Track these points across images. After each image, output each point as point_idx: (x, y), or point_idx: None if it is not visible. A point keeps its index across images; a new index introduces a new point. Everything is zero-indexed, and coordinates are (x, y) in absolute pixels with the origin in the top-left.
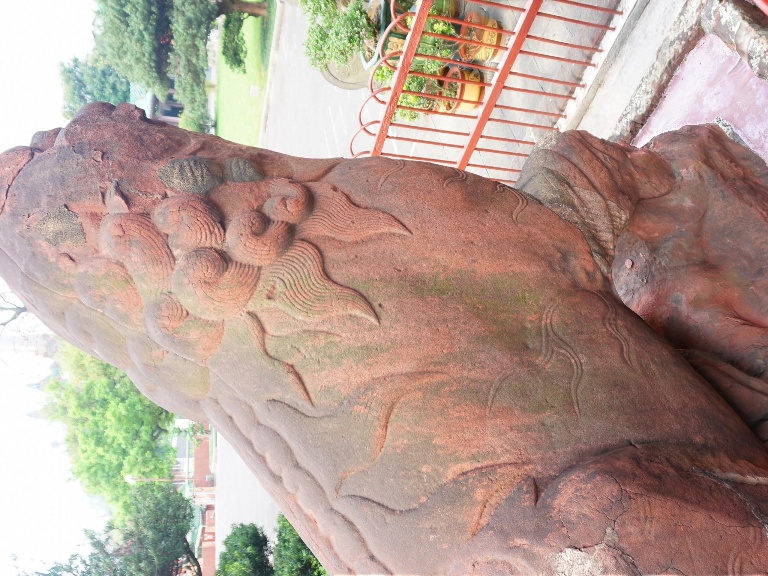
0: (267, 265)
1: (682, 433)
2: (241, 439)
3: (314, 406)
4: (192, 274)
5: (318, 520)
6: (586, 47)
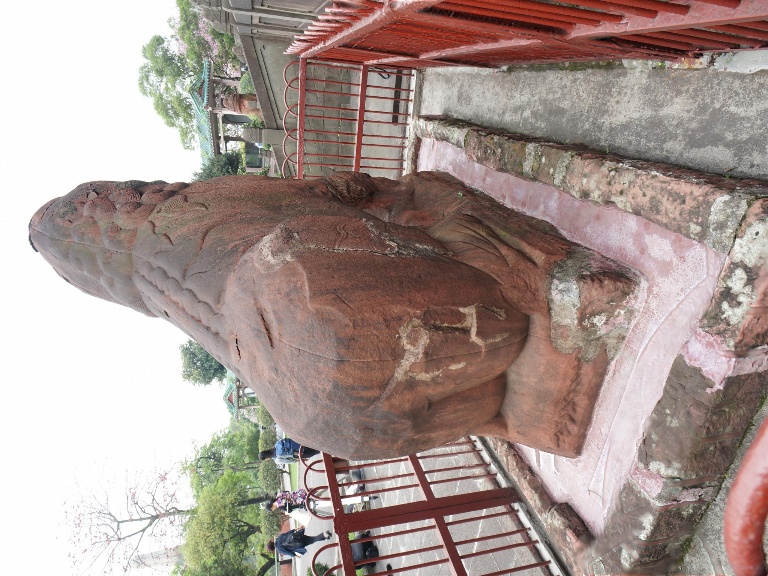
0: (159, 203)
1: None
2: (147, 283)
3: (173, 245)
4: (122, 210)
5: (178, 300)
6: None
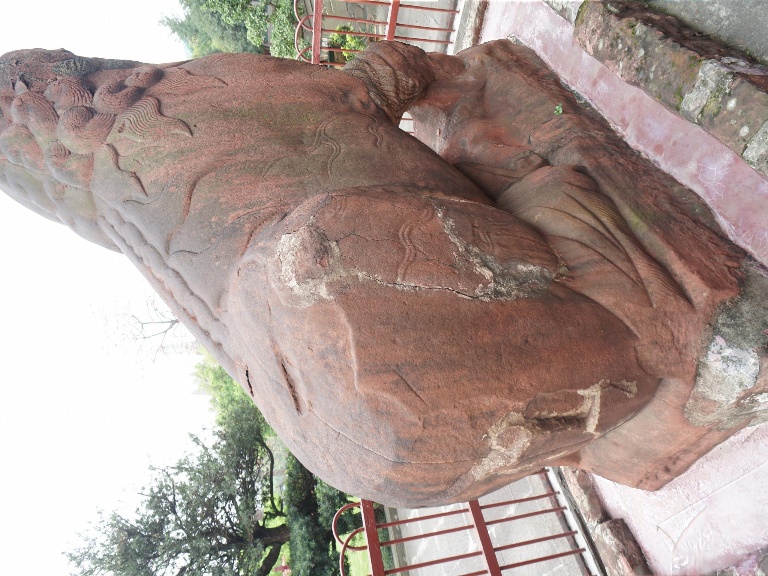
0: (121, 113)
1: (408, 180)
2: (119, 239)
3: (148, 196)
4: (66, 122)
5: (163, 280)
6: (442, 29)
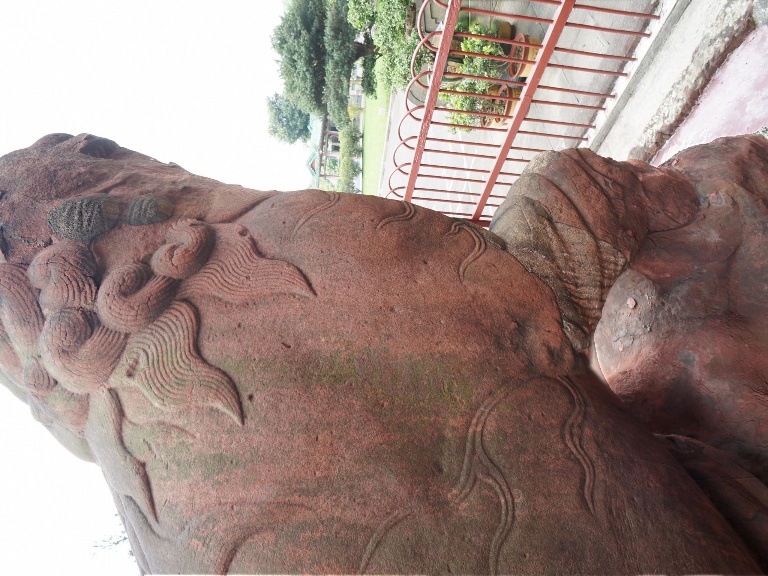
0: (136, 332)
1: None
2: None
3: (158, 522)
4: (50, 341)
5: None
6: (618, 57)
